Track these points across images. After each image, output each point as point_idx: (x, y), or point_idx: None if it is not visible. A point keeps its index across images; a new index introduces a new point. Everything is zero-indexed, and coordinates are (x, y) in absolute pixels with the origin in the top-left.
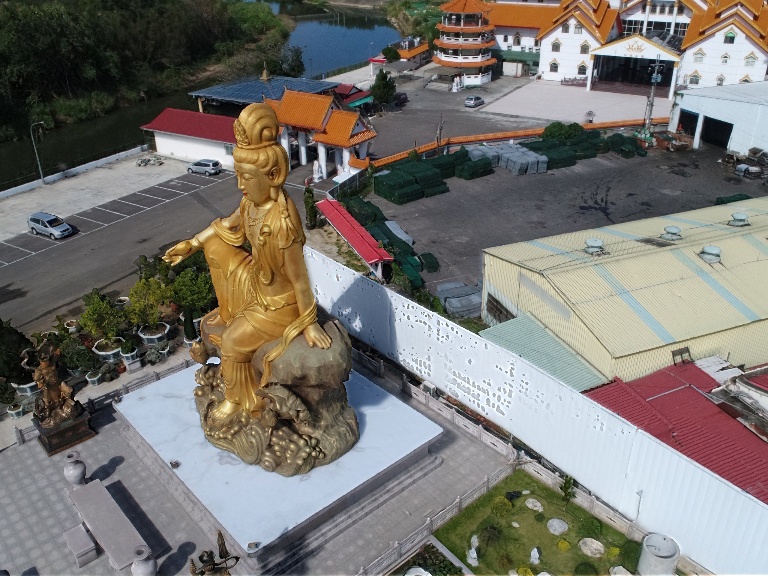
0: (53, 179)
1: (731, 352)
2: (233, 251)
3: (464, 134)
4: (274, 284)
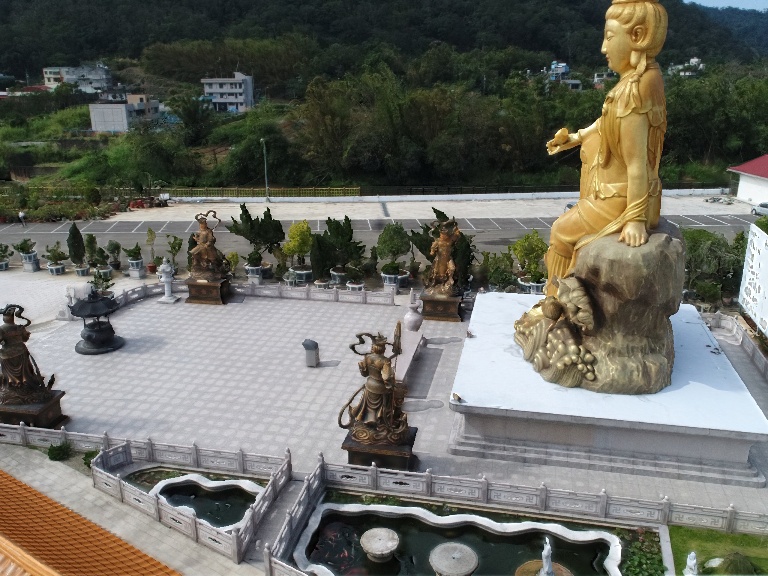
0: None
1: None
2: None
3: None
4: (610, 167)
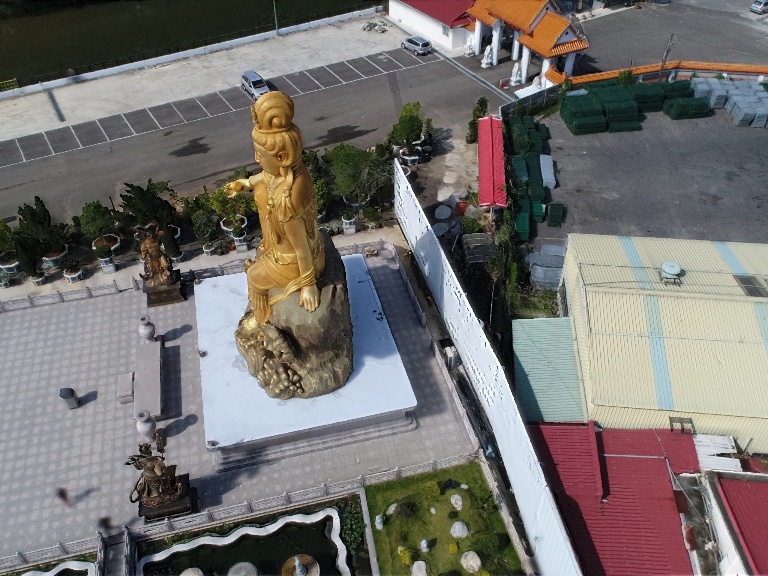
0: (287, 31)
1: (755, 438)
2: None
3: (701, 59)
4: (282, 244)
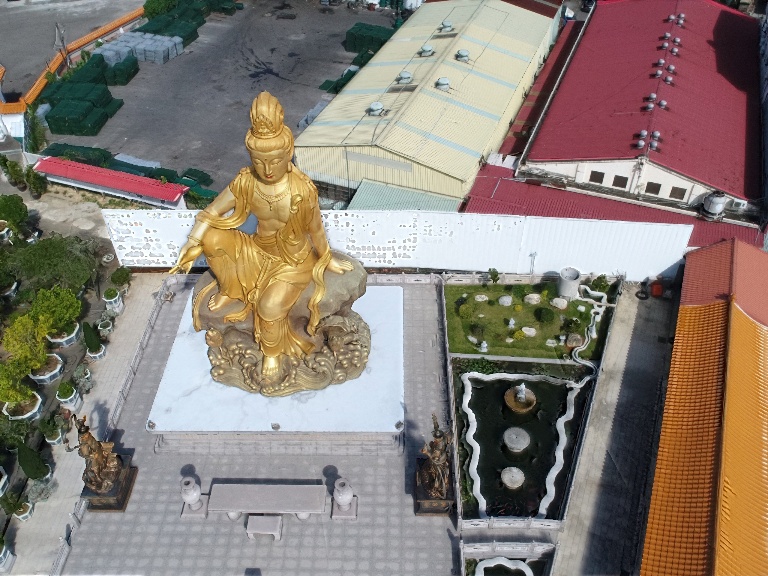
0: None
1: (492, 147)
2: (231, 234)
3: (77, 37)
4: (300, 241)
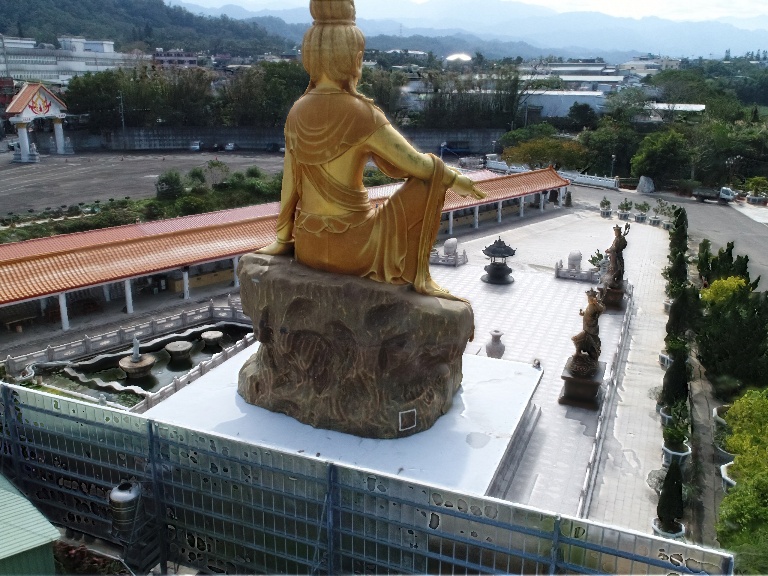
0: None
1: None
2: None
3: None
4: None
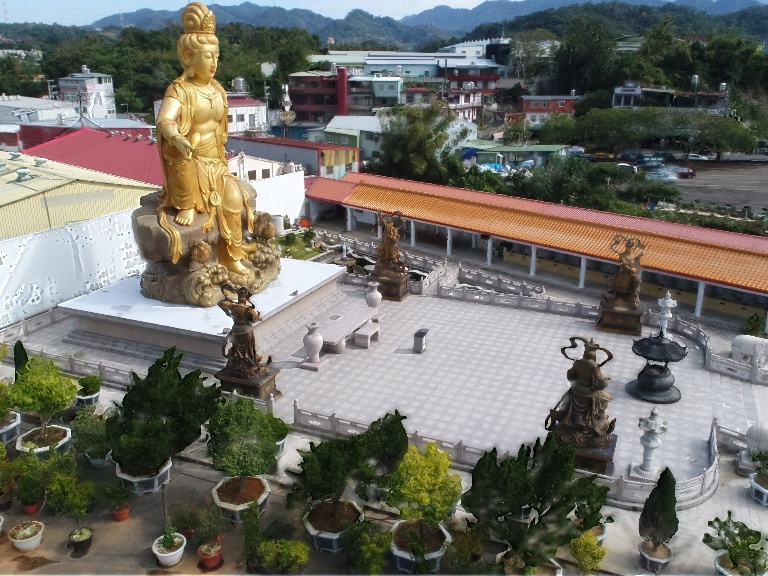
0: None
1: None
2: None
3: None
4: None
